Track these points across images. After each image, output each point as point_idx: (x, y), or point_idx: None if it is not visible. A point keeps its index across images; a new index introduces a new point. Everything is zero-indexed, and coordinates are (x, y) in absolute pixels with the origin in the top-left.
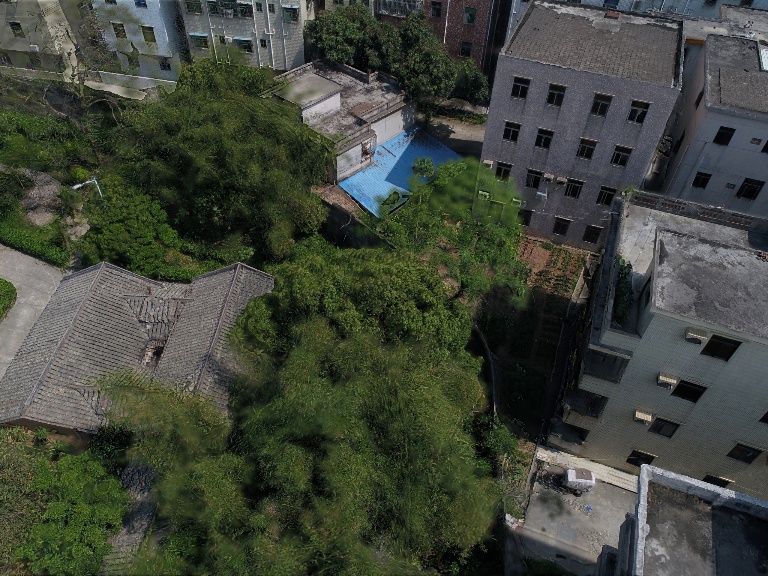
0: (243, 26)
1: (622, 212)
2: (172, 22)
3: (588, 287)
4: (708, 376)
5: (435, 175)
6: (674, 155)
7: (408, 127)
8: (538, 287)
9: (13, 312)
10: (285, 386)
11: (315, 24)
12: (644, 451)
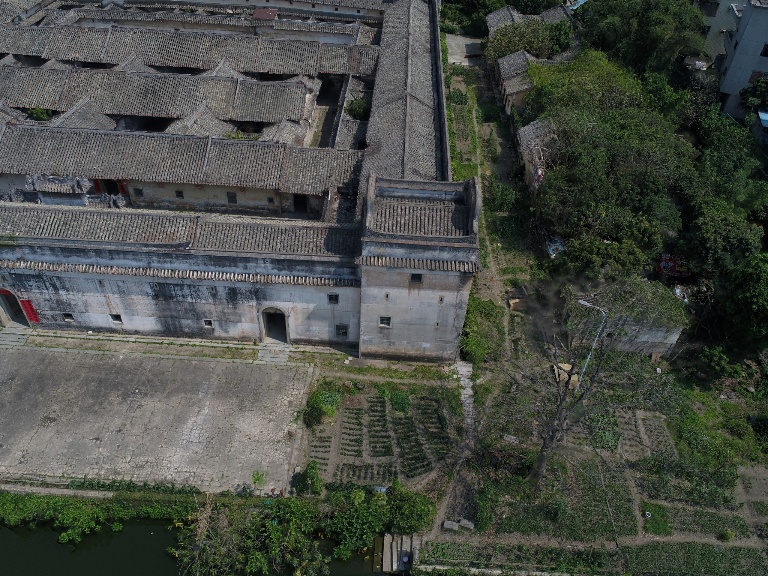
0: None
1: None
2: None
3: None
4: (745, 3)
5: None
6: None
7: None
8: None
9: None
10: None
11: None
12: (722, 53)
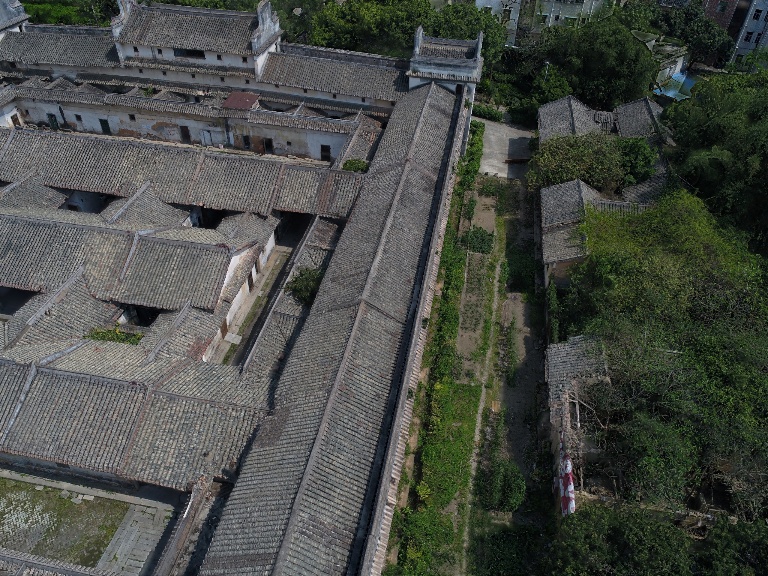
0: (574, 9)
1: None
2: (520, 8)
3: None
4: None
5: None
6: None
7: (682, 70)
8: None
9: (485, 136)
10: (742, 101)
11: (623, 8)
12: None
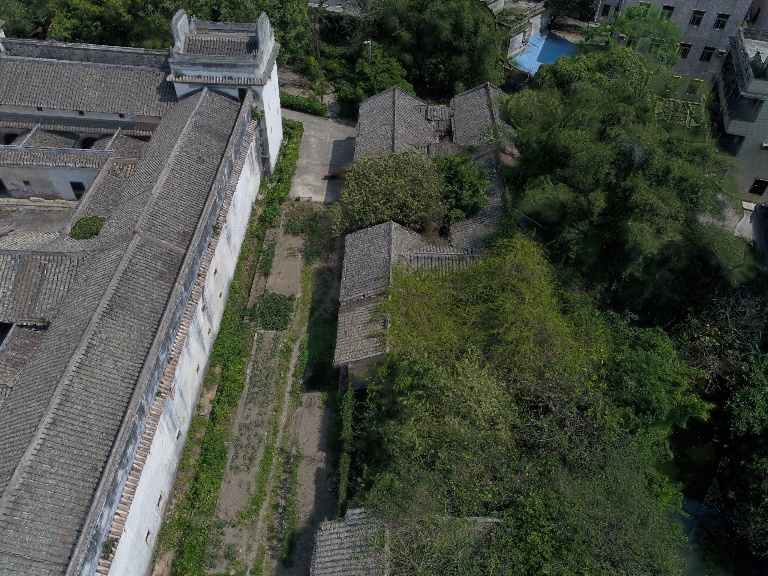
0: None
1: (739, 38)
2: None
3: (695, 120)
4: None
5: None
6: (752, 26)
7: (542, 29)
8: (661, 120)
9: (304, 140)
10: (588, 99)
11: None
12: (762, 179)
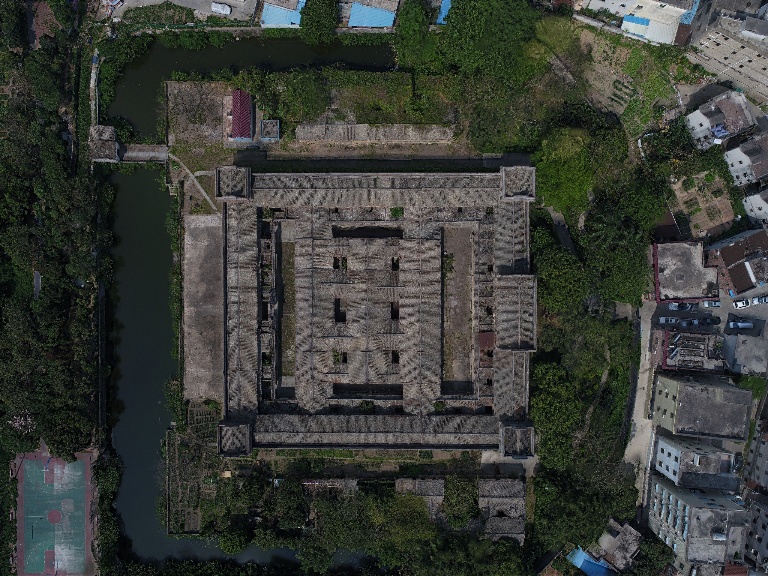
0: None
1: None
2: None
3: None
4: None
5: (591, 575)
6: None
7: None
8: None
9: None
10: (478, 567)
11: None
12: None
